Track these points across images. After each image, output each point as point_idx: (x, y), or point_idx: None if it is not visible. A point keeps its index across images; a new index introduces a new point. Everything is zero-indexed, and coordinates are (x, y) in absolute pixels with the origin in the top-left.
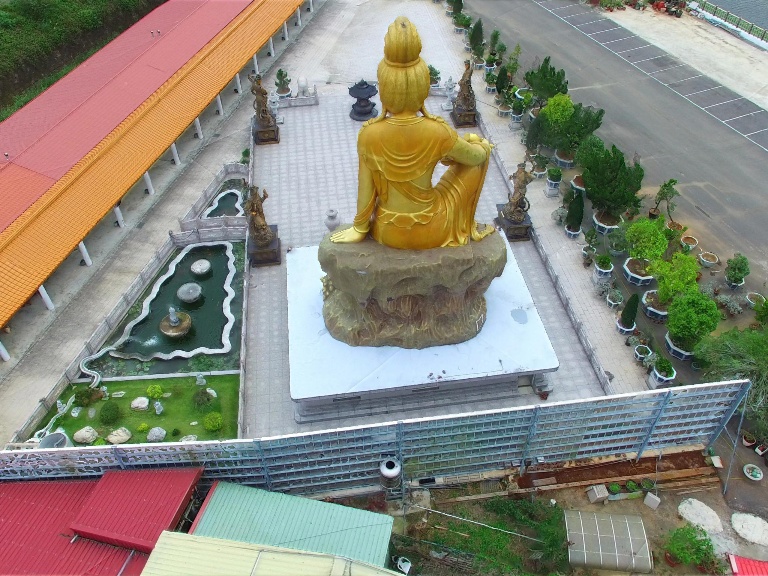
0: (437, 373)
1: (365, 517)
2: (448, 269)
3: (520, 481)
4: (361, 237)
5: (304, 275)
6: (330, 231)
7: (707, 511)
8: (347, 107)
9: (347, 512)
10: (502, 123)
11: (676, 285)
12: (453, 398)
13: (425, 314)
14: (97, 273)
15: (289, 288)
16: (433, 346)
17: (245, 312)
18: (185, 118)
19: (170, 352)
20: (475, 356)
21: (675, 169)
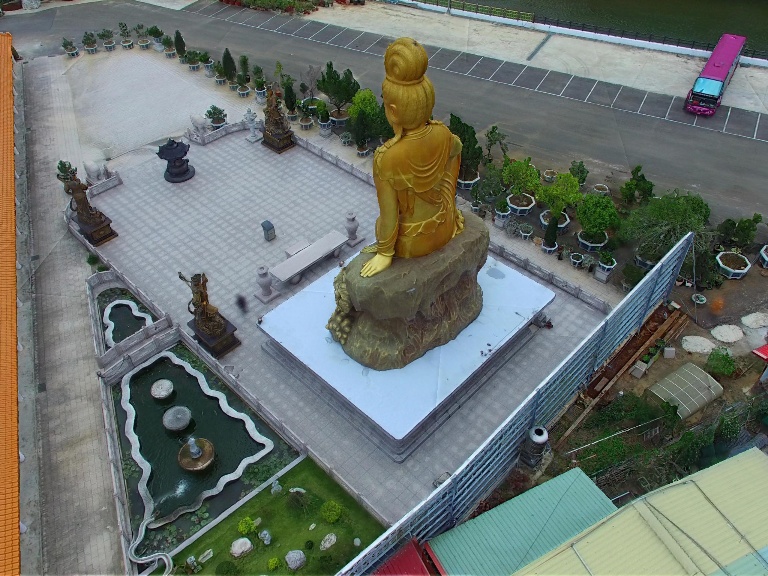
0: (485, 349)
1: (562, 482)
2: (469, 253)
3: (589, 394)
4: (391, 260)
5: (296, 335)
6: (264, 289)
7: (698, 339)
8: (156, 174)
9: (546, 488)
10: (312, 135)
11: (575, 197)
12: (496, 365)
13: (451, 305)
14: (41, 463)
15: (295, 354)
16: (462, 331)
17: (259, 402)
18: (5, 251)
19: (216, 484)
20: (497, 320)
21: (469, 121)
